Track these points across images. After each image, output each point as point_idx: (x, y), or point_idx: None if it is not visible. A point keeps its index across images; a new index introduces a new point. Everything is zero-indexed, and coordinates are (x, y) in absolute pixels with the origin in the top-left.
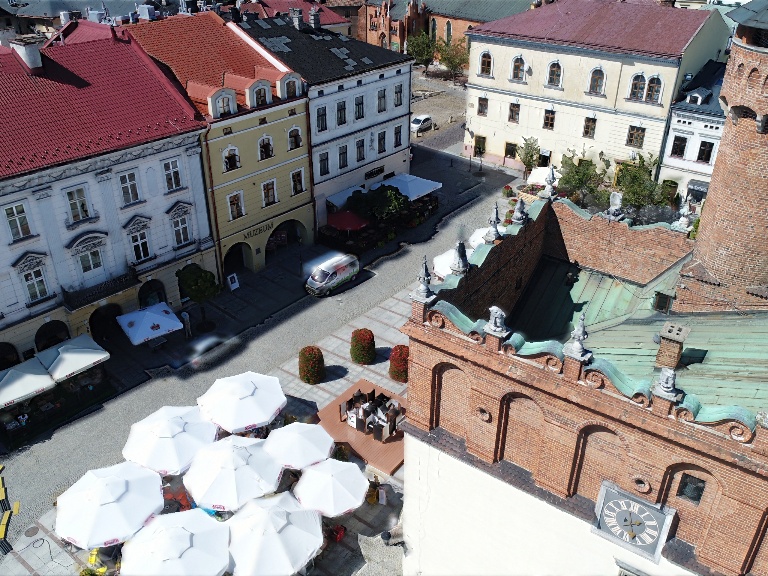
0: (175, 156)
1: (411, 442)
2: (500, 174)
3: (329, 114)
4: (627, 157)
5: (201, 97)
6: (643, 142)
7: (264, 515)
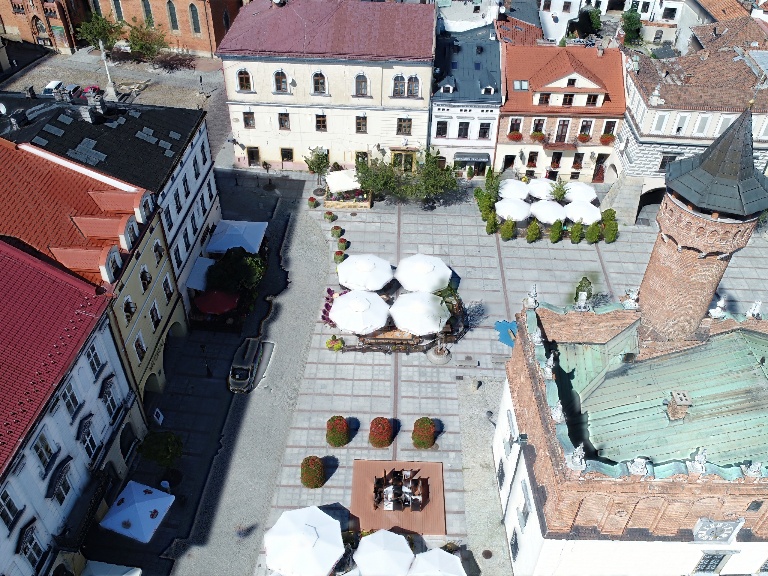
0: (92, 341)
1: (551, 541)
2: (288, 181)
3: (171, 209)
4: (400, 144)
5: (88, 267)
6: (411, 130)
7: None
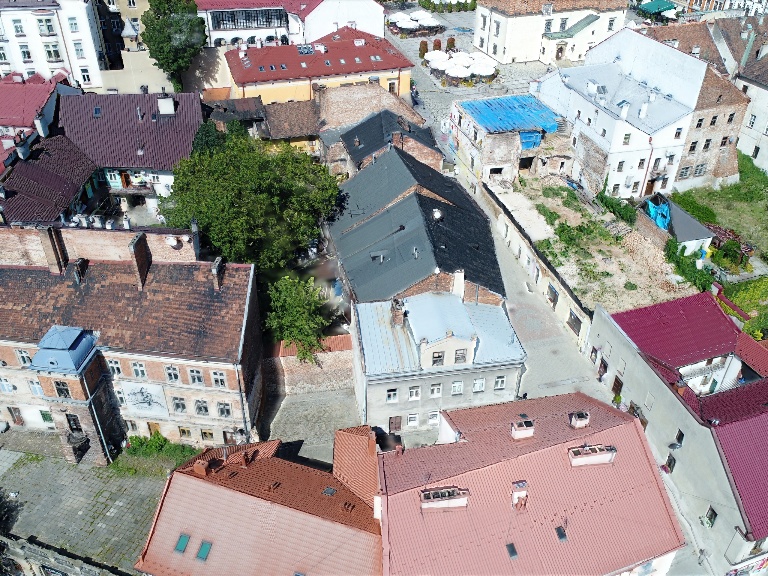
0: None
1: None
2: None
3: None
4: None
5: None
6: None
7: (487, 56)
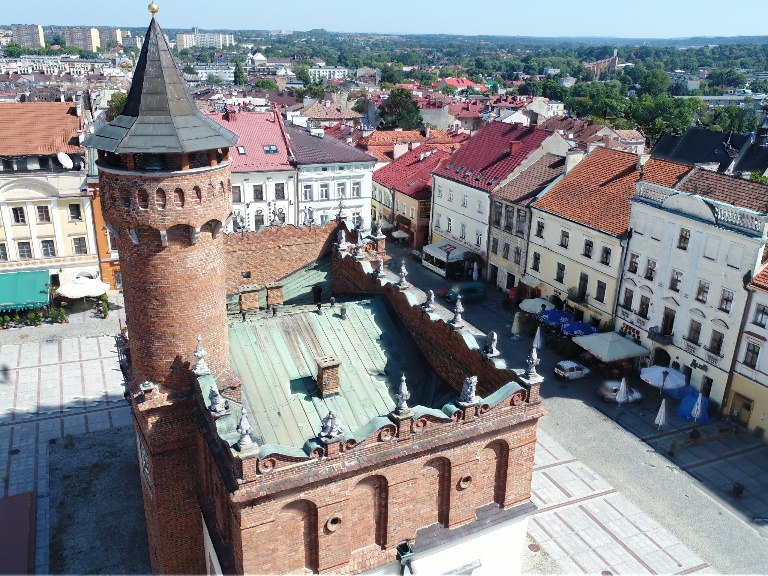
0: None
1: None
2: None
3: None
4: None
5: None
6: None
7: None
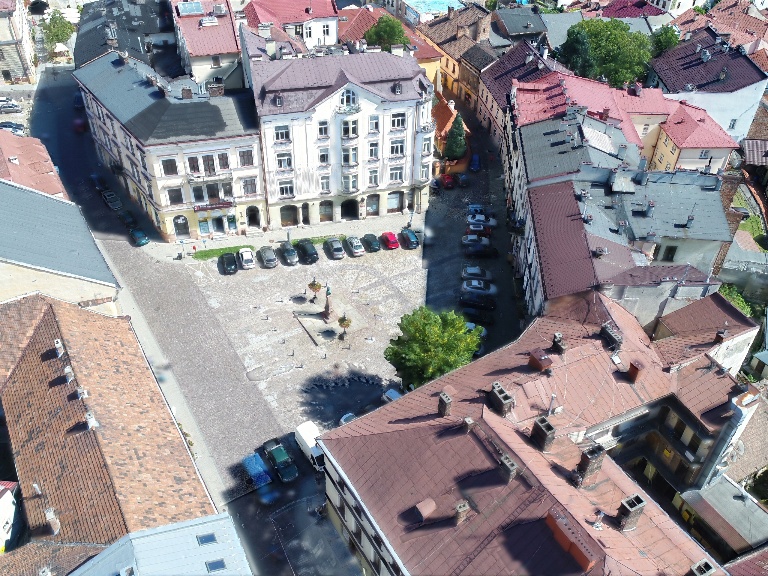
0: None
1: None
2: (48, 70)
3: None
4: None
5: None
6: None
7: None
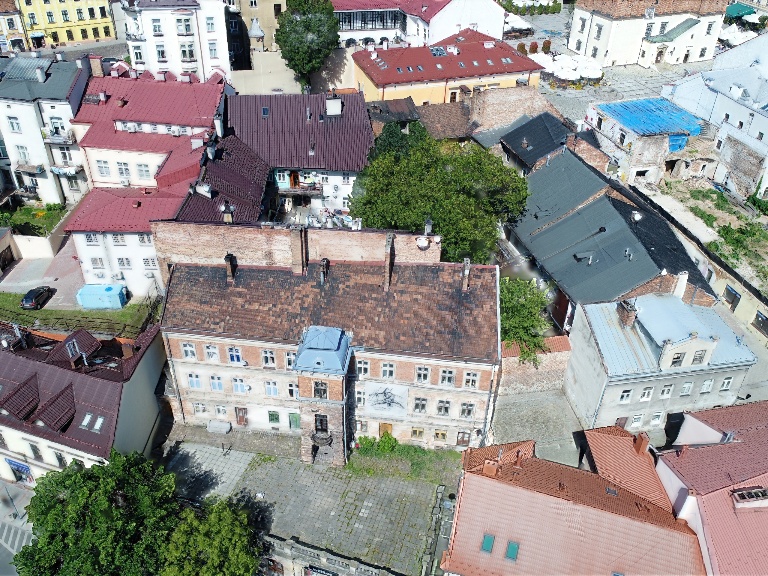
0: None
1: None
2: None
3: None
4: None
5: None
6: None
7: None
